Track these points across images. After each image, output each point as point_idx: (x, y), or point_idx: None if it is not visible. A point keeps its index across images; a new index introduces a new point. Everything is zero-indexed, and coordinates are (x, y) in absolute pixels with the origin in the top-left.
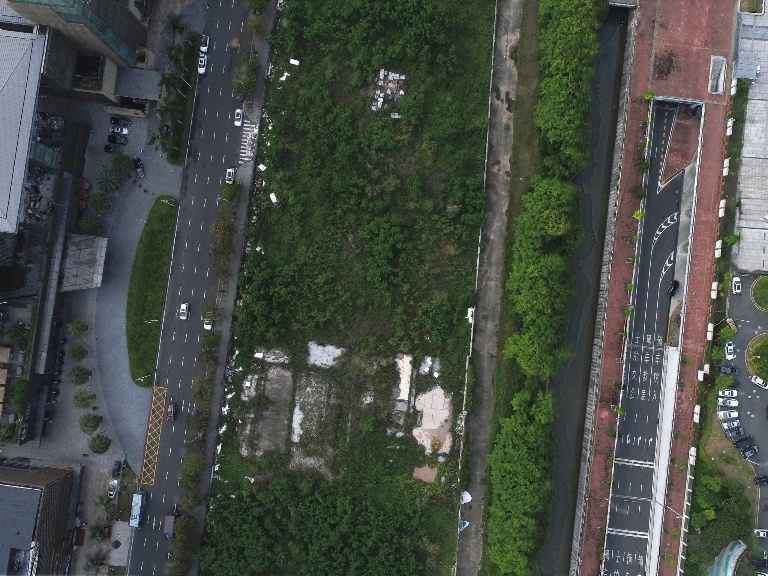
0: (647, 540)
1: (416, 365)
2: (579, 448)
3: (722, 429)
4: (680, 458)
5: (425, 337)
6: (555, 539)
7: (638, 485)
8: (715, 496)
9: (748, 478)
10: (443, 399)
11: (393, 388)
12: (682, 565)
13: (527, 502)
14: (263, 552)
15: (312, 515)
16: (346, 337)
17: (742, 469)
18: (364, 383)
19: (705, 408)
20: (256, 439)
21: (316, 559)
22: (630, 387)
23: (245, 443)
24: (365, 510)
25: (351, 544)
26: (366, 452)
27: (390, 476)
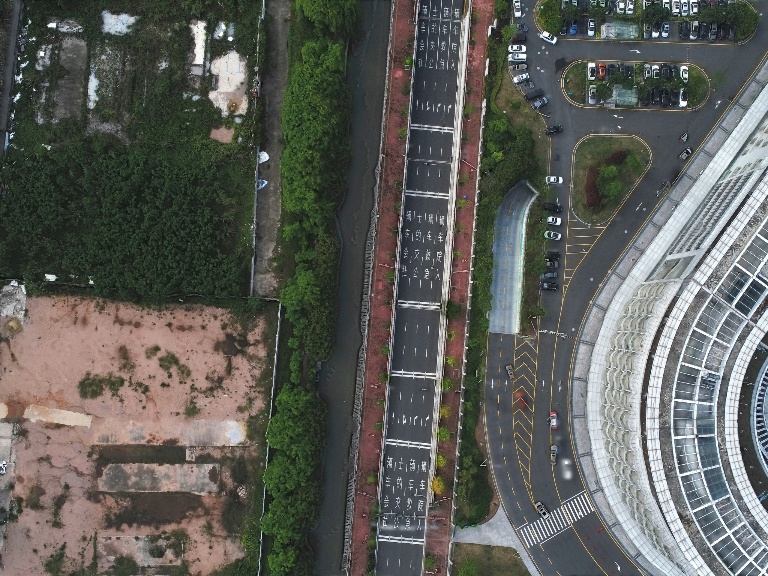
0: (448, 201)
1: (210, 30)
2: (379, 115)
3: (513, 84)
4: (473, 113)
5: (219, 3)
6: (354, 196)
7: (438, 149)
8: (500, 134)
9: (539, 129)
10: (238, 63)
11: (188, 53)
12: (476, 212)
13: (311, 136)
14: (56, 208)
15: (105, 171)
16: (139, 4)
17: (533, 121)
18: (159, 49)
19: (495, 63)
20: (51, 107)
21: (109, 211)
22: (429, 57)
23: (40, 111)
24: (159, 166)
25: (145, 197)
26: (162, 114)
27: (186, 137)
